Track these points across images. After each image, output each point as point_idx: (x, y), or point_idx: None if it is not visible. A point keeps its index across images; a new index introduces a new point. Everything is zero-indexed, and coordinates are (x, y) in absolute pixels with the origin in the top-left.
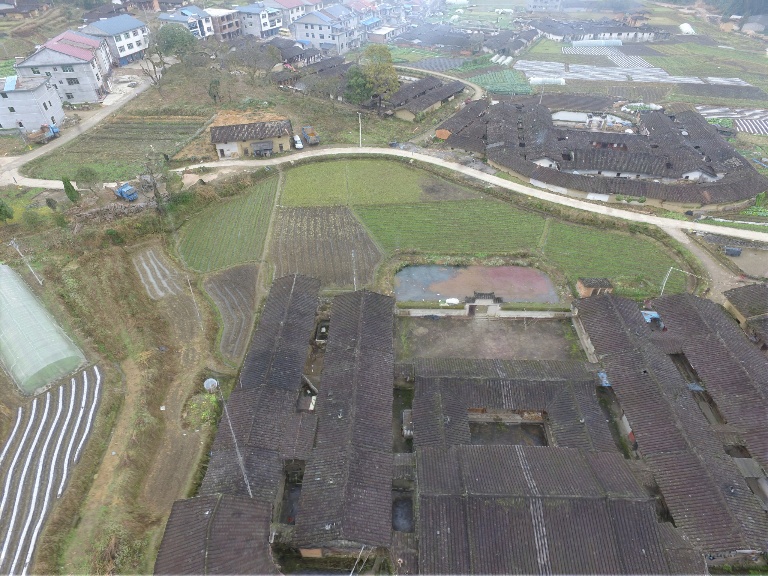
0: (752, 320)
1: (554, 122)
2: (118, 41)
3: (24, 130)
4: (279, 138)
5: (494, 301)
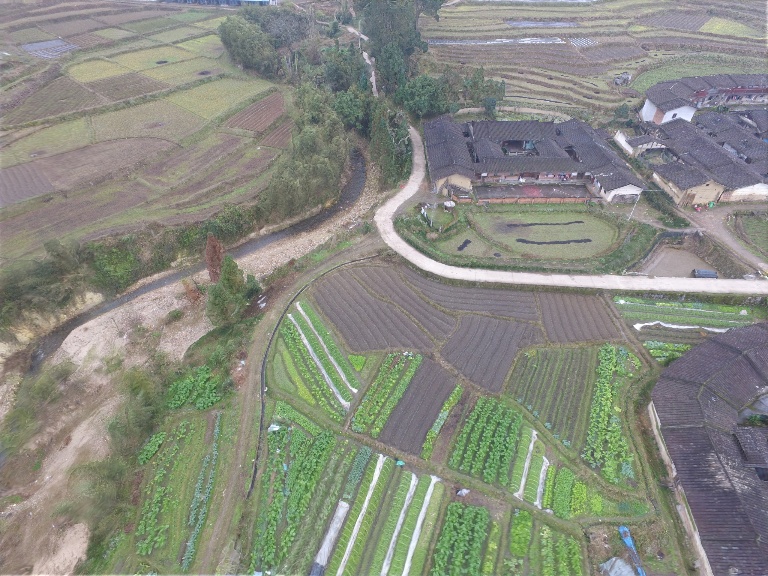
0: None
1: None
2: None
3: None
4: None
5: None
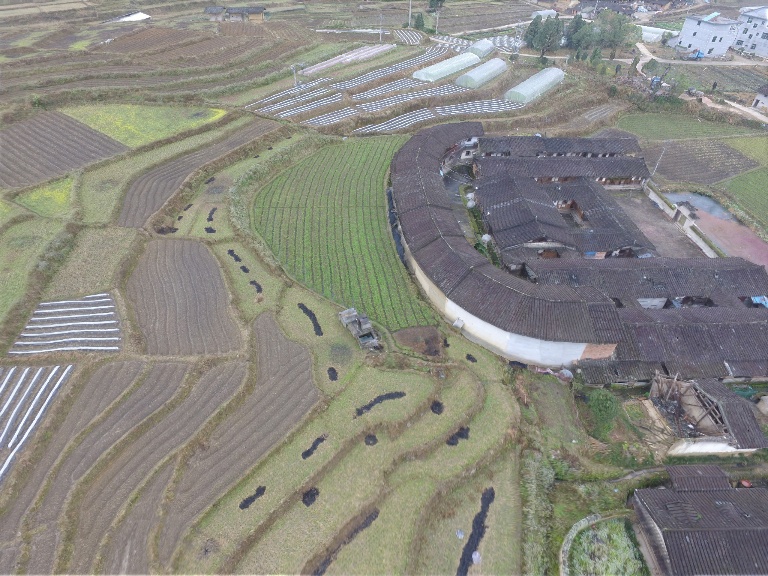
0: None
1: None
2: None
3: None
4: None
5: (690, 214)
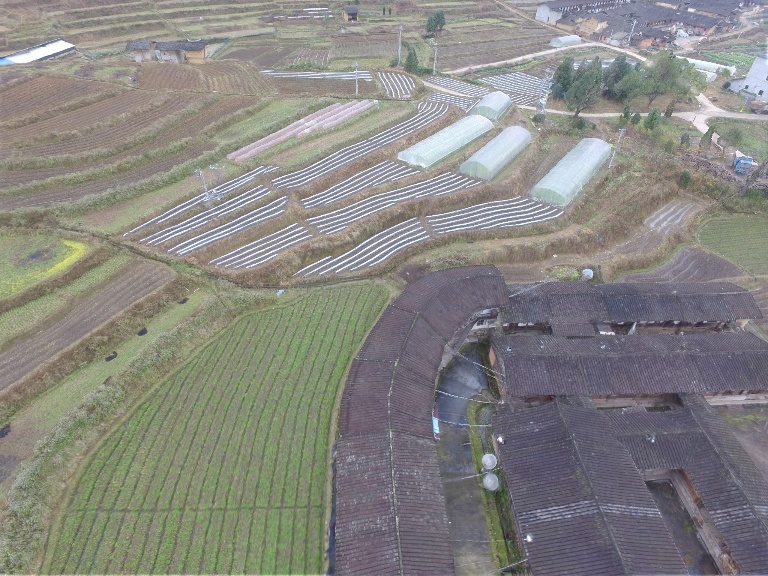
0: None
1: None
2: None
3: (759, 98)
4: None
5: None
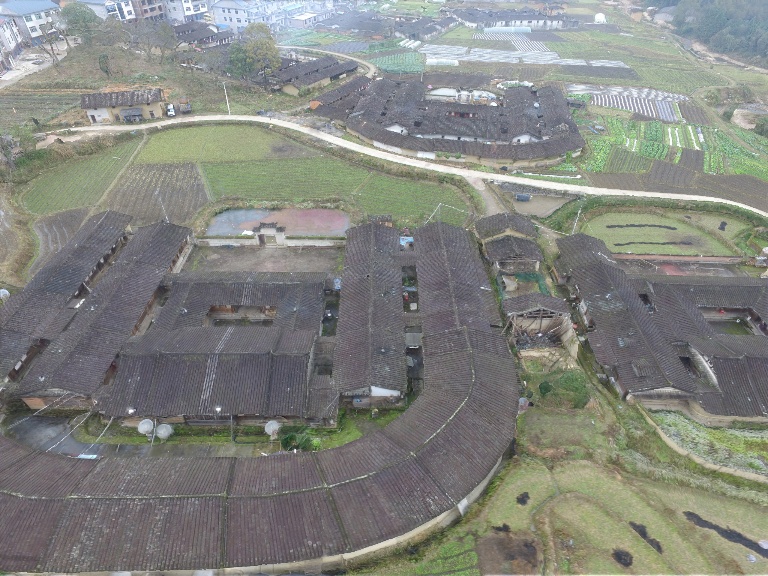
0: (488, 242)
1: (428, 96)
2: (29, 21)
3: None
4: (148, 105)
5: (277, 230)
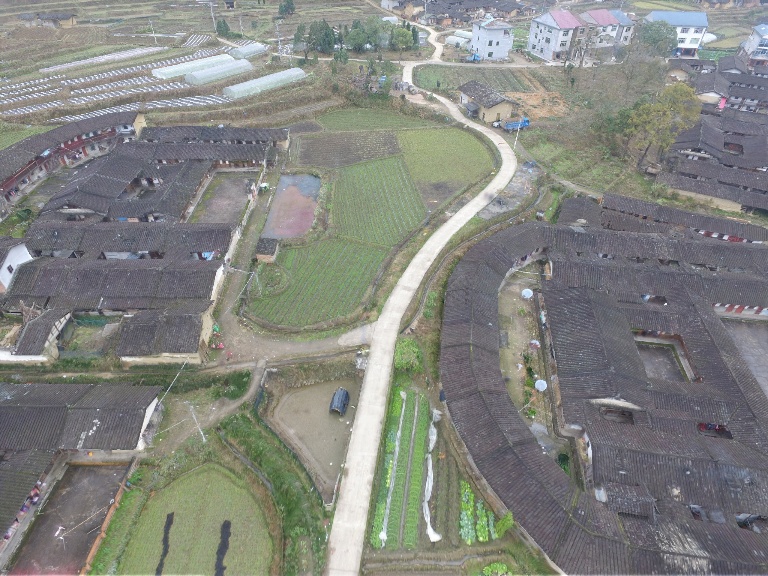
0: None
1: None
2: None
3: None
4: (485, 108)
5: None
